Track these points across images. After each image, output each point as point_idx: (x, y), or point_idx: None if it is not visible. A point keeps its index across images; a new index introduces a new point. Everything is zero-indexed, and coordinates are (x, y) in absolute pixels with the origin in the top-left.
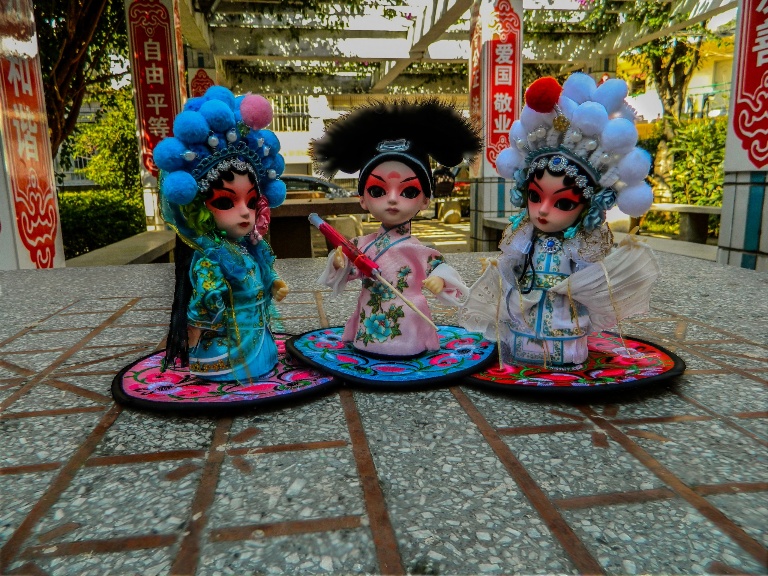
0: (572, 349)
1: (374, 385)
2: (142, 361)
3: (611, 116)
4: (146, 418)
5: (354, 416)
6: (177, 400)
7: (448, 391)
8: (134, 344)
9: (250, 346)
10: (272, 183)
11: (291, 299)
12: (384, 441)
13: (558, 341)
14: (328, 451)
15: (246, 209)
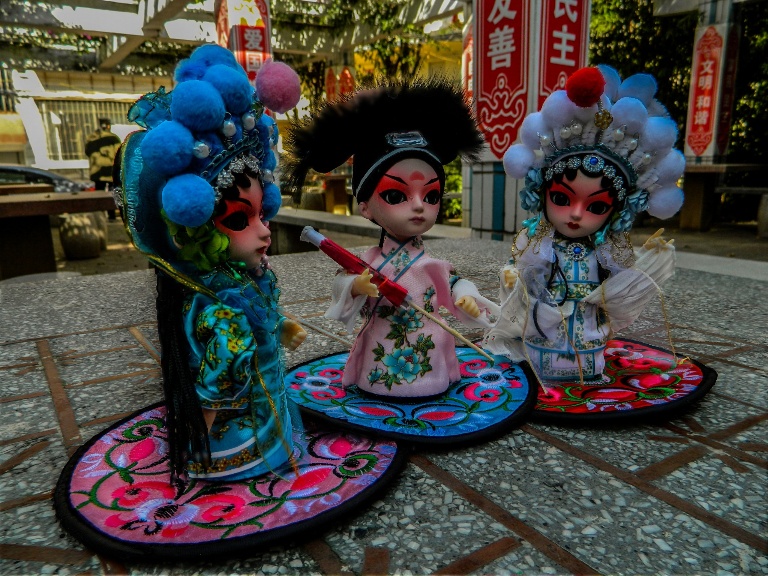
0: (600, 360)
1: (453, 443)
2: (76, 469)
3: None
4: (187, 575)
5: (474, 494)
6: (230, 533)
7: (523, 432)
8: (17, 438)
9: (279, 421)
10: (268, 188)
11: None
12: (552, 524)
13: (589, 353)
14: (512, 560)
15: (265, 228)
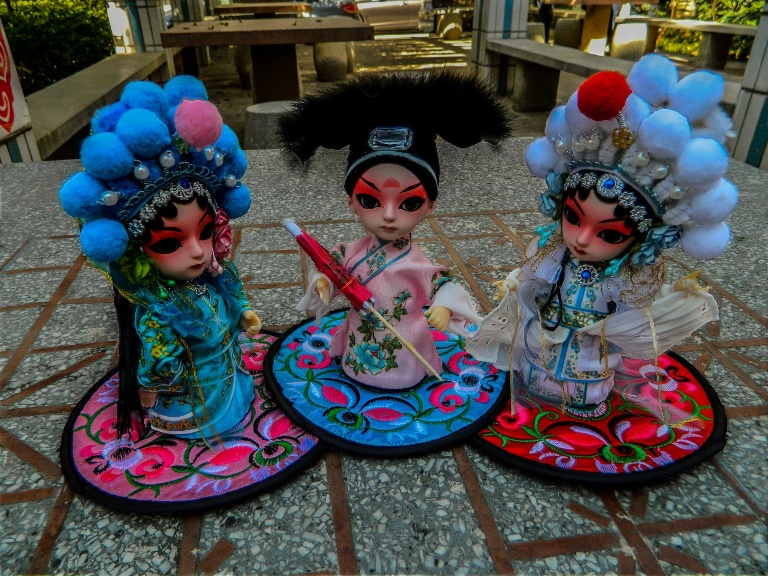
0: (596, 390)
1: (366, 454)
2: (97, 391)
3: (693, 127)
4: (101, 515)
5: (343, 515)
6: (135, 493)
7: (451, 456)
8: (89, 344)
9: (219, 401)
10: (231, 193)
11: (271, 241)
12: (378, 573)
13: (581, 383)
14: None
15: (198, 248)
